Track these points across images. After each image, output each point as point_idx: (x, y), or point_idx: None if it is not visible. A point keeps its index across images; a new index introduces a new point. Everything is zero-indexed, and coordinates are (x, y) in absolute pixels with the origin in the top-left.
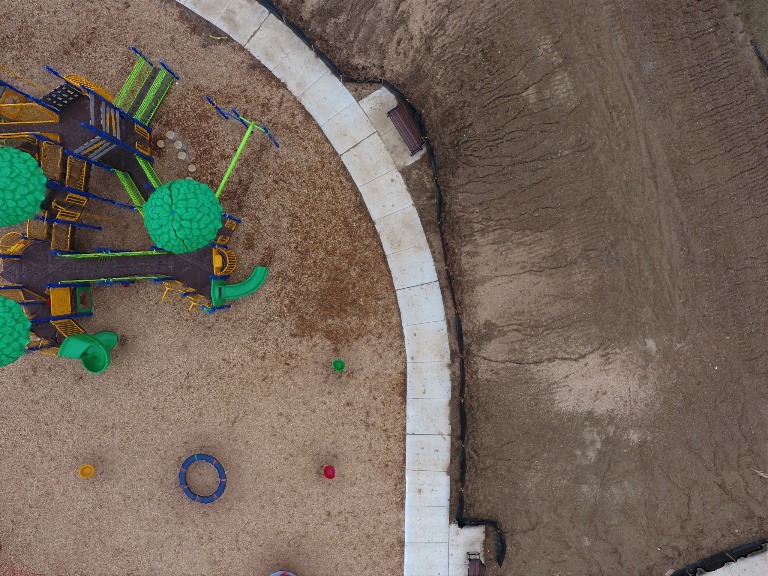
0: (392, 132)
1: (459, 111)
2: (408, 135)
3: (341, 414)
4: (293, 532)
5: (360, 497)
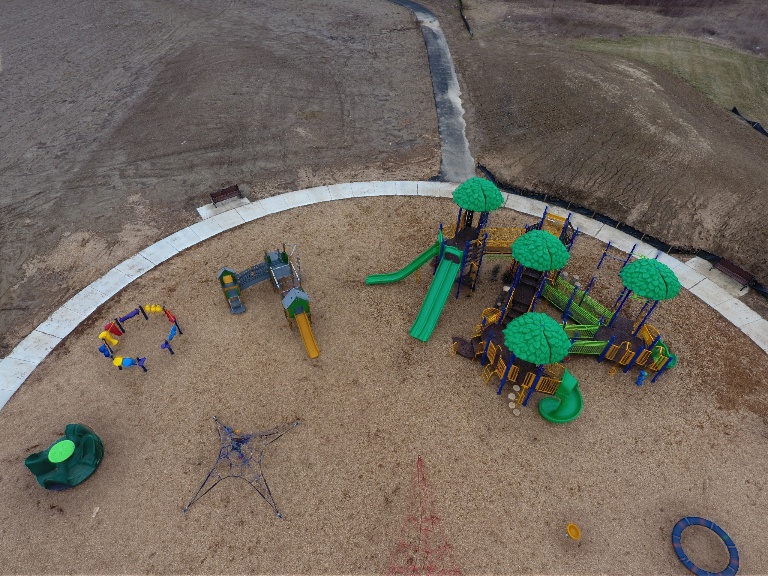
0: (718, 278)
1: (763, 265)
2: (736, 276)
3: None
4: None
5: None
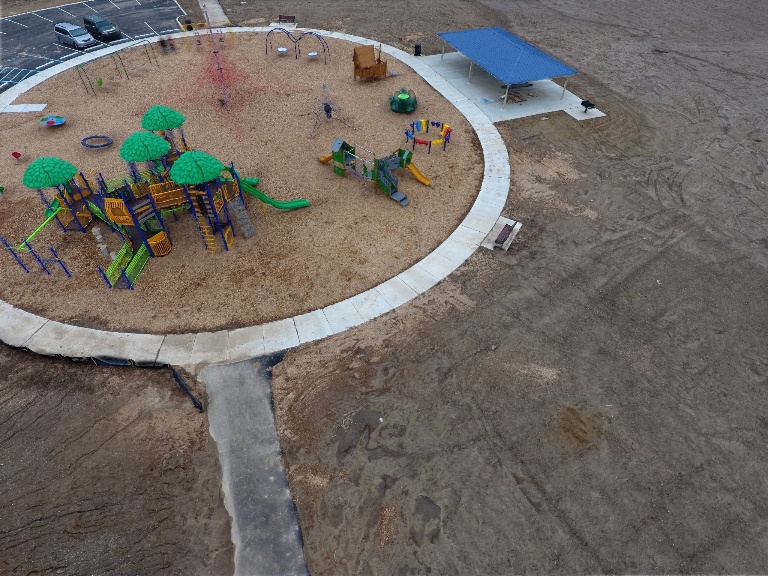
0: None
1: None
2: None
3: (8, 177)
4: None
5: (4, 155)
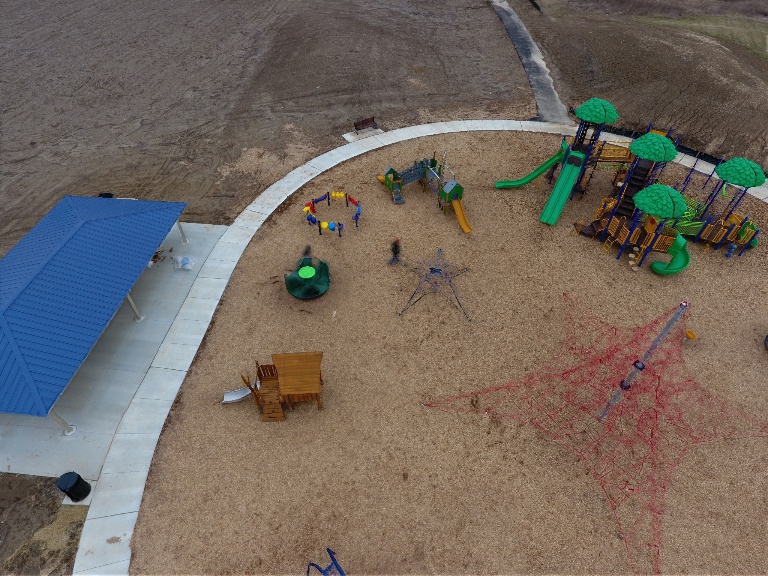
0: None
1: None
2: None
3: None
4: None
5: None
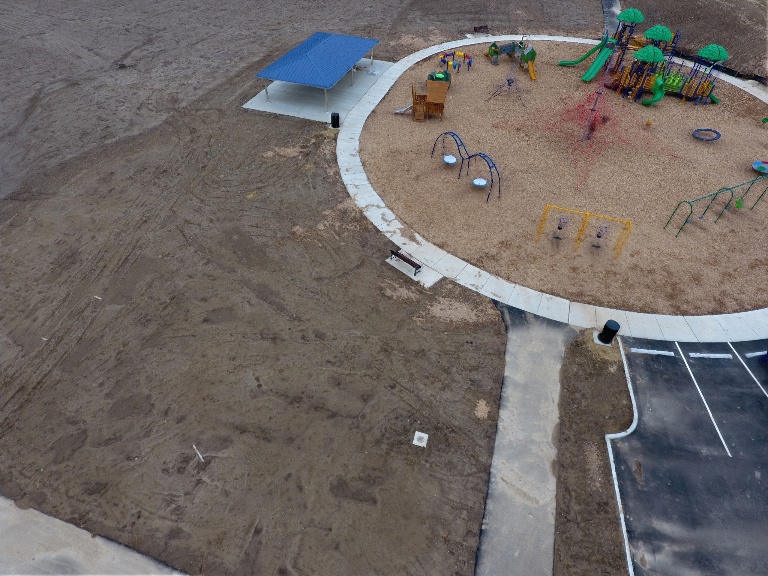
0: (761, 87)
1: None
2: None
3: None
4: (758, 159)
5: None
